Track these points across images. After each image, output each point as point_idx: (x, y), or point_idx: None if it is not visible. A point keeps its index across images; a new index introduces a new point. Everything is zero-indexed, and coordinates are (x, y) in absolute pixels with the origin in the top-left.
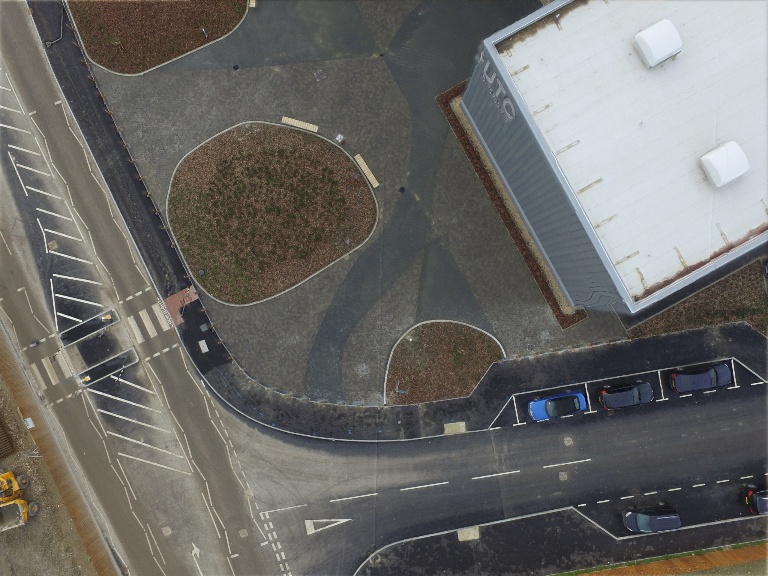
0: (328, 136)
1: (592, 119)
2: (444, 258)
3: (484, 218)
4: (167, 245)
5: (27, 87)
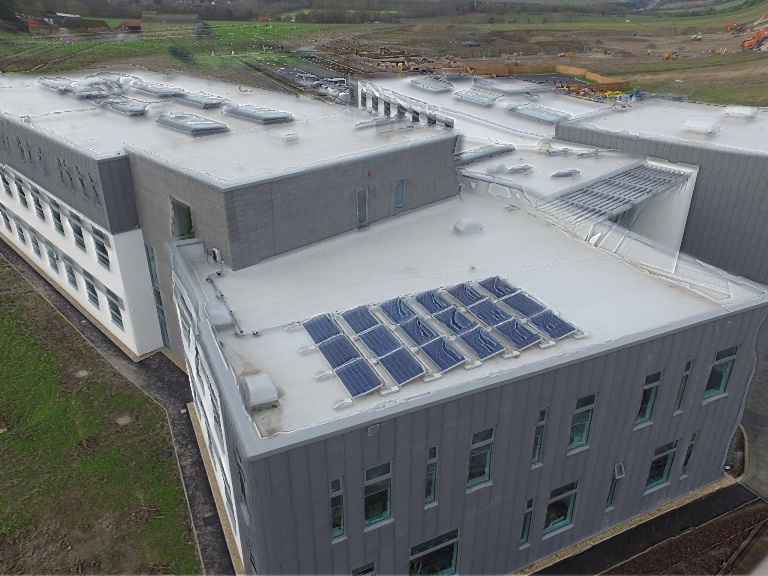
0: None
1: None
2: None
3: None
4: None
5: None
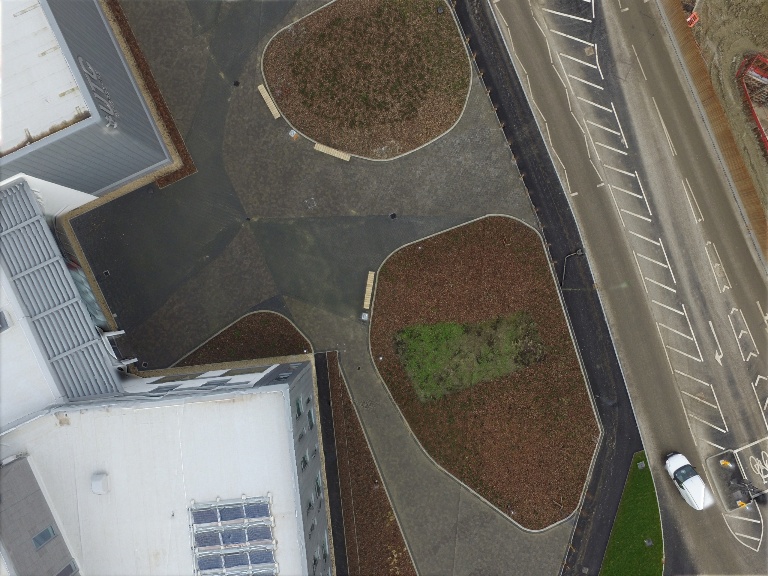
0: (306, 142)
1: (0, 37)
2: (199, 12)
3: (156, 48)
4: (474, 42)
5: (604, 212)
